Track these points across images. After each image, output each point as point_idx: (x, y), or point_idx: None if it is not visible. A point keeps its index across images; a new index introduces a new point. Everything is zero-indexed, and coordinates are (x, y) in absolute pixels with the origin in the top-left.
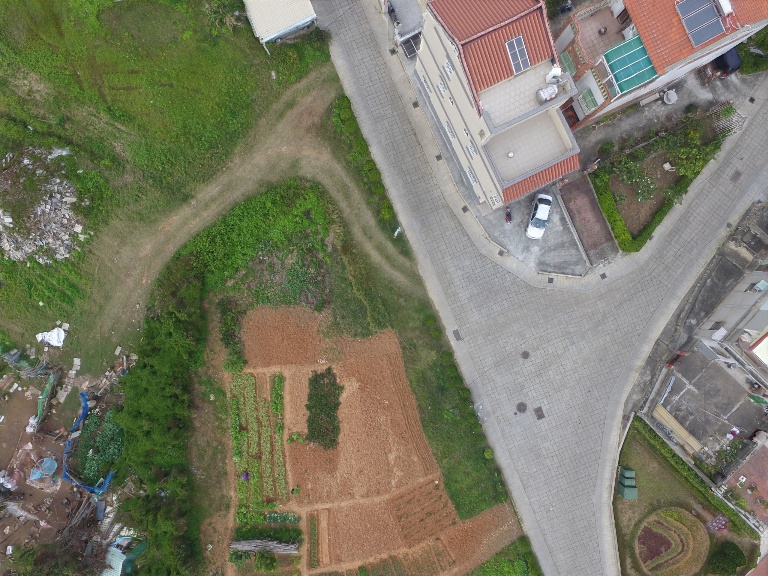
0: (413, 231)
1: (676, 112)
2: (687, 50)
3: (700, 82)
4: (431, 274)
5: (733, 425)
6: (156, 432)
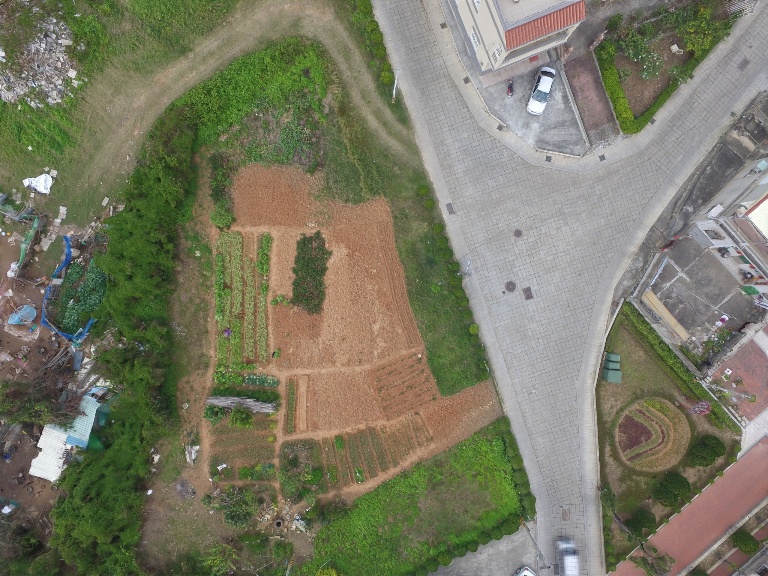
0: (412, 99)
1: None
2: None
3: None
4: (428, 144)
5: (723, 312)
6: (138, 275)
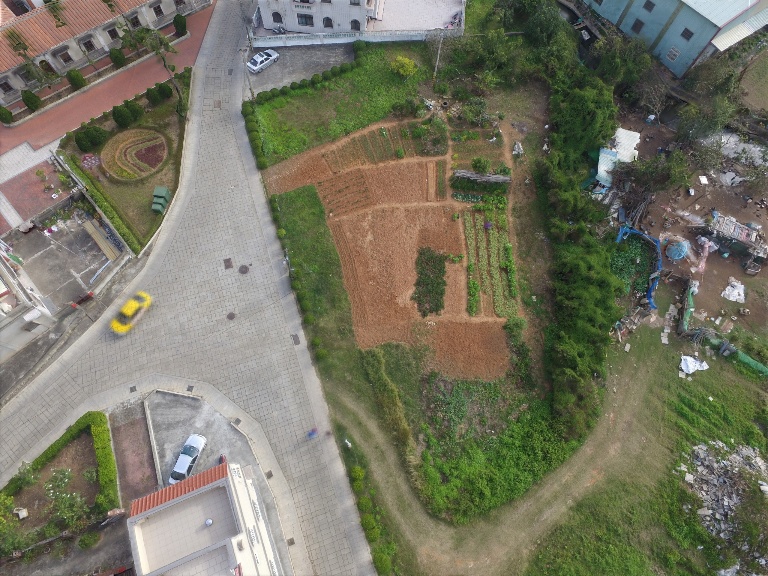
0: (330, 453)
1: None
2: None
3: None
4: (315, 404)
5: None
6: (582, 268)
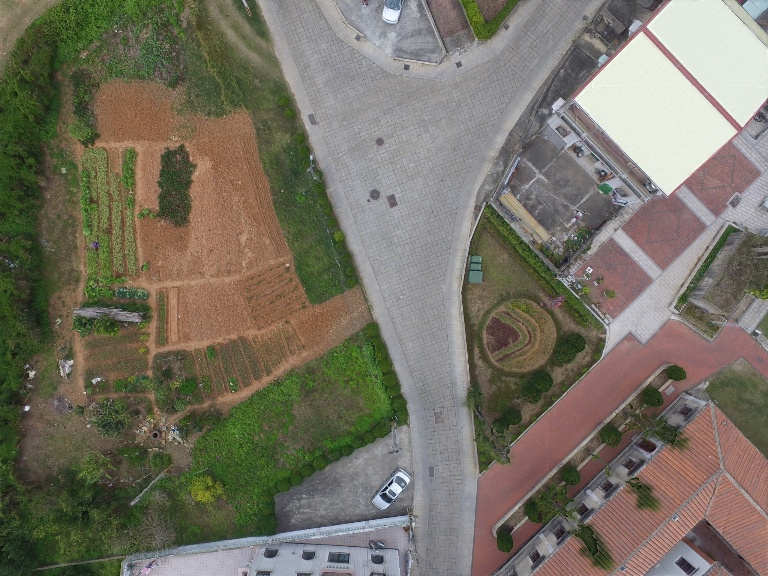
0: (270, 12)
1: None
2: None
3: None
4: (288, 57)
5: (576, 208)
6: None
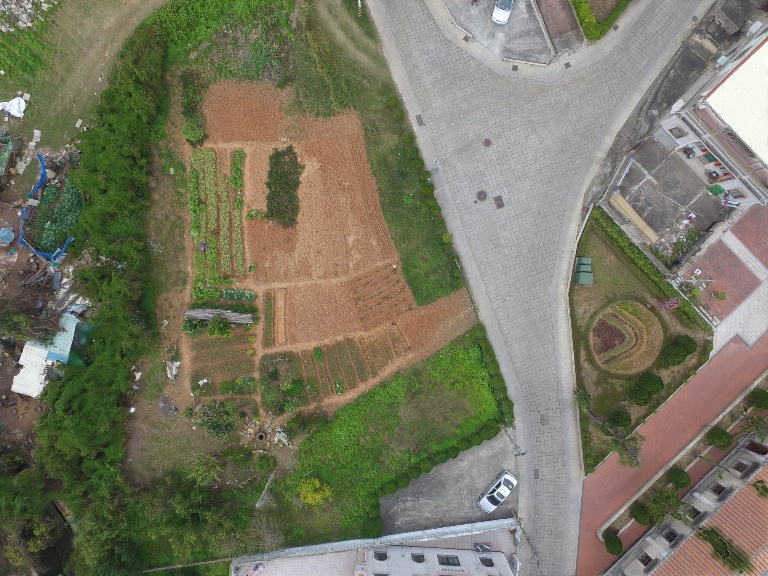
0: (379, 13)
1: None
2: None
3: None
4: (396, 57)
5: None
6: (112, 188)
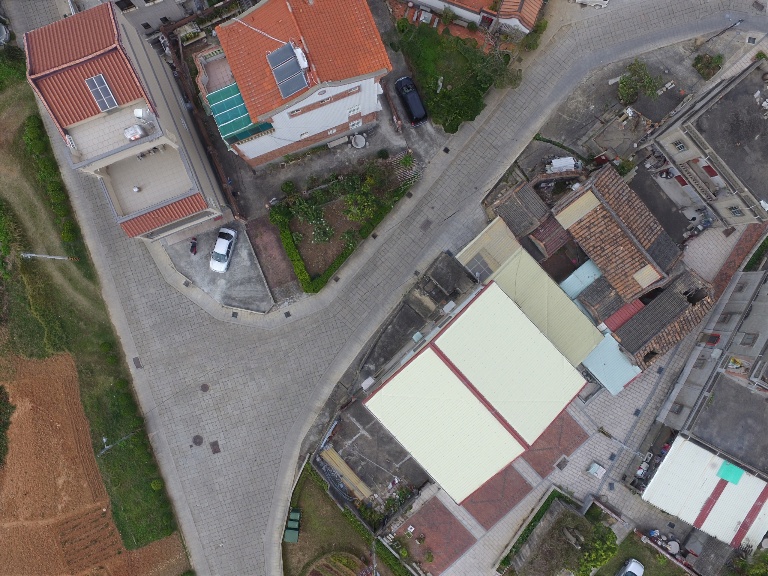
0: (99, 255)
1: (368, 156)
2: (278, 101)
3: (394, 128)
4: (115, 299)
5: (393, 475)
6: None
